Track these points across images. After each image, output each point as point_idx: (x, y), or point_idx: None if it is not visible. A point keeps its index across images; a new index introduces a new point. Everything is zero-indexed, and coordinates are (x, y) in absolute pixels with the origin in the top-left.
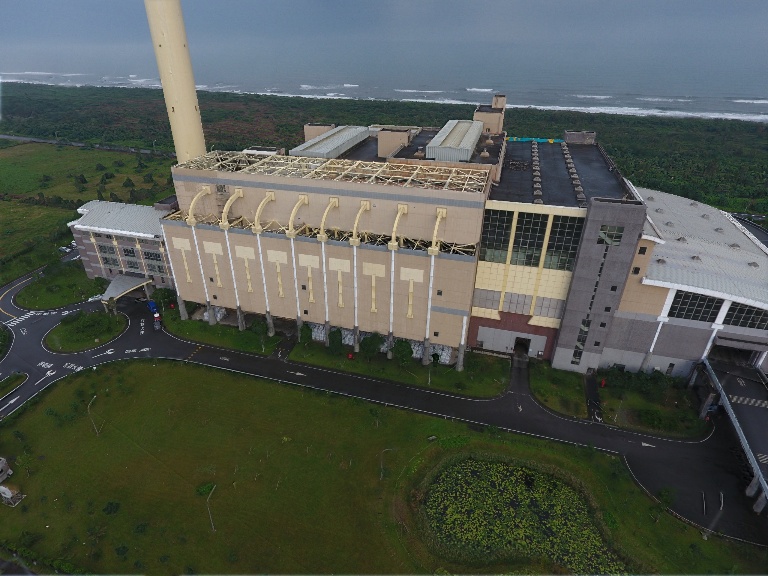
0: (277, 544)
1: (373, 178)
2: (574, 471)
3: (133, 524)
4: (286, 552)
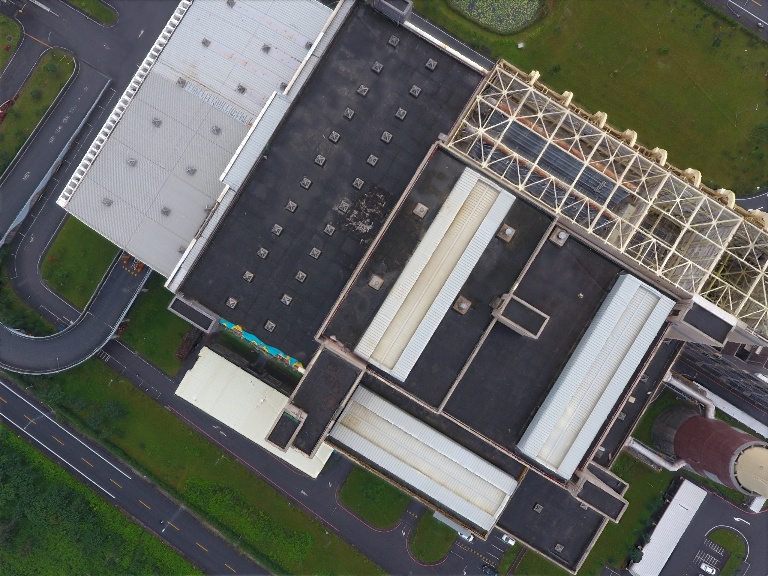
0: (624, 6)
1: (591, 155)
2: (441, 4)
3: (701, 39)
4: (620, 1)
